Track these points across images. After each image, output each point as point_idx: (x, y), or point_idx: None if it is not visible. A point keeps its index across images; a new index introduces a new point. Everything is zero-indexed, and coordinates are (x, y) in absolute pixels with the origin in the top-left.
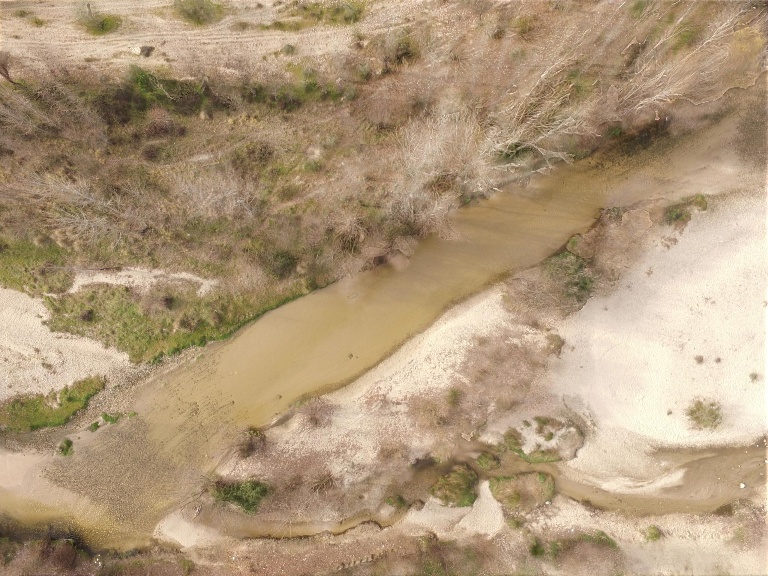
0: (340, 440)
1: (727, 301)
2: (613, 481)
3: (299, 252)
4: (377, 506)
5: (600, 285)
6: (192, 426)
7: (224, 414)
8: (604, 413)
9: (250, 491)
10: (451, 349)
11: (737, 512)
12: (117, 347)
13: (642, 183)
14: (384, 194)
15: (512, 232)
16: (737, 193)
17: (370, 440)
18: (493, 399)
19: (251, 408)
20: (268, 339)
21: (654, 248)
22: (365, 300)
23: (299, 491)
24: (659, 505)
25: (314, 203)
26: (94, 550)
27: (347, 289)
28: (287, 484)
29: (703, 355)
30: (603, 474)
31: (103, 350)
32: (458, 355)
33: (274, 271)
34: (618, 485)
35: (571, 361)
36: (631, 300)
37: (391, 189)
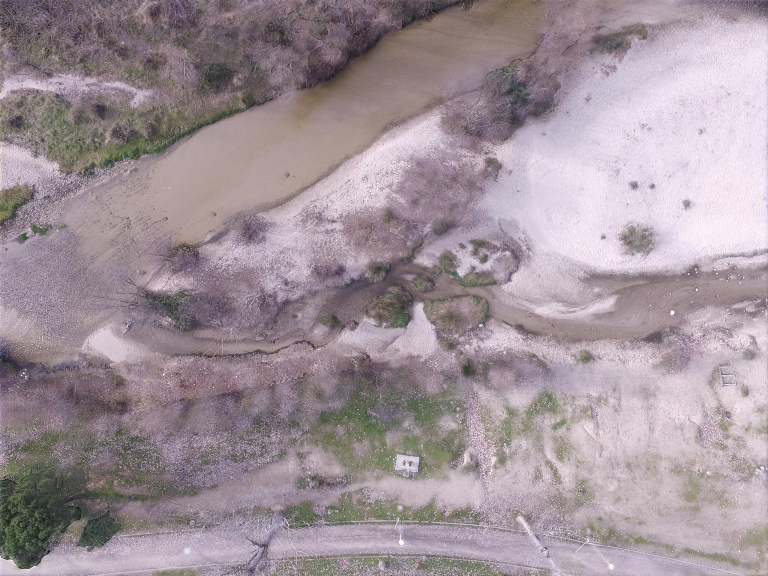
0: (274, 257)
1: (663, 128)
2: (546, 306)
3: (236, 65)
4: (311, 326)
5: (533, 89)
6: (124, 241)
7: (157, 230)
8: (539, 237)
9: (179, 299)
10: (389, 169)
11: (667, 339)
12: (47, 156)
13: (584, 10)
14: (324, 7)
15: (453, 55)
16: (677, 23)
17: (305, 258)
18: (429, 220)
19: (185, 225)
20: (204, 155)
21: (594, 75)
22: (303, 119)
23: (231, 307)
24: (591, 331)
25: (253, 15)
26: (20, 364)
27: (285, 107)
28: (219, 298)
29: (638, 181)
30: (537, 299)
31: (32, 159)
32: (395, 175)
33: (210, 82)
34: (551, 310)
35: (508, 185)
36: (569, 125)
37: (331, 4)
